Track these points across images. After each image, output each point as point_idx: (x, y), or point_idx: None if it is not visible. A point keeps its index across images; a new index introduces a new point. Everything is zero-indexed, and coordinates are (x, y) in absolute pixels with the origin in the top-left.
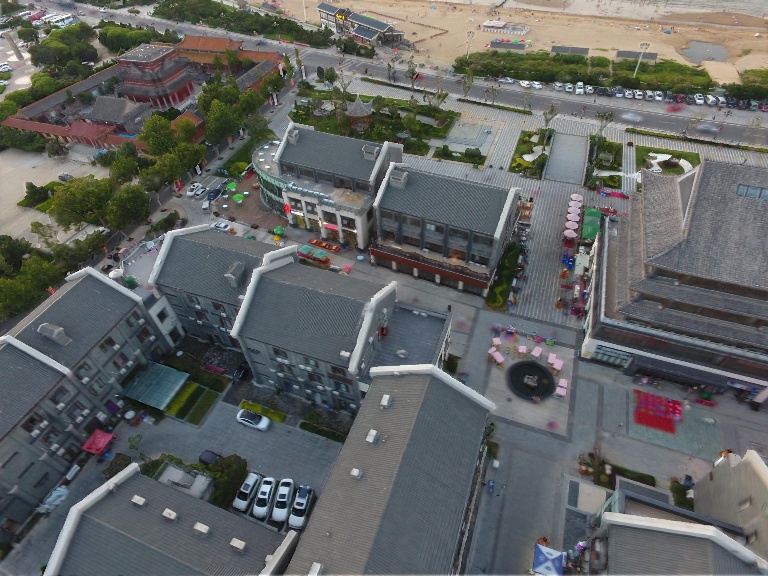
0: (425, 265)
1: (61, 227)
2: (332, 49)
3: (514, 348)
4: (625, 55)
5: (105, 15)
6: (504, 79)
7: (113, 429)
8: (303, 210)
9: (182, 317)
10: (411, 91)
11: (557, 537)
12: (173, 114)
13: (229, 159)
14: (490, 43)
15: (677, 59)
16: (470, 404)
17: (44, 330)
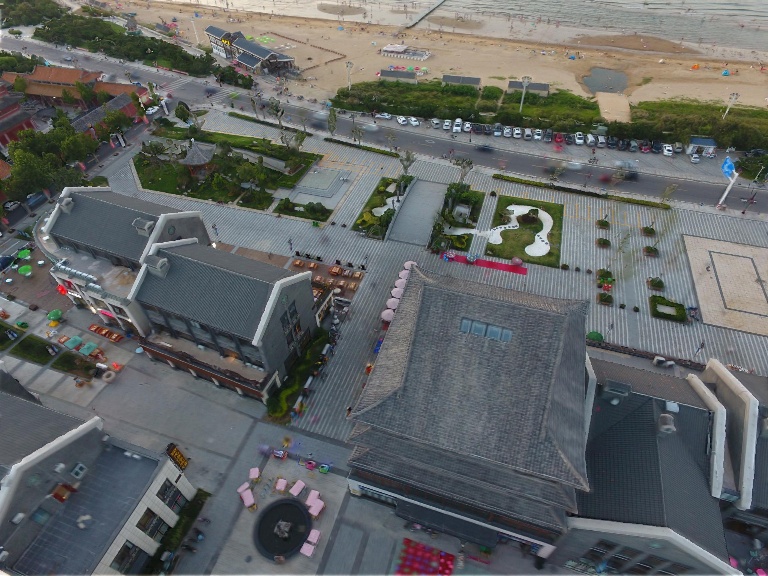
0: (195, 367)
1: None
2: (212, 78)
3: (275, 481)
4: (517, 86)
5: None
6: (381, 115)
7: None
8: (79, 292)
9: None
10: (278, 129)
11: None
12: None
13: None
14: (380, 71)
15: (573, 89)
16: None
17: None
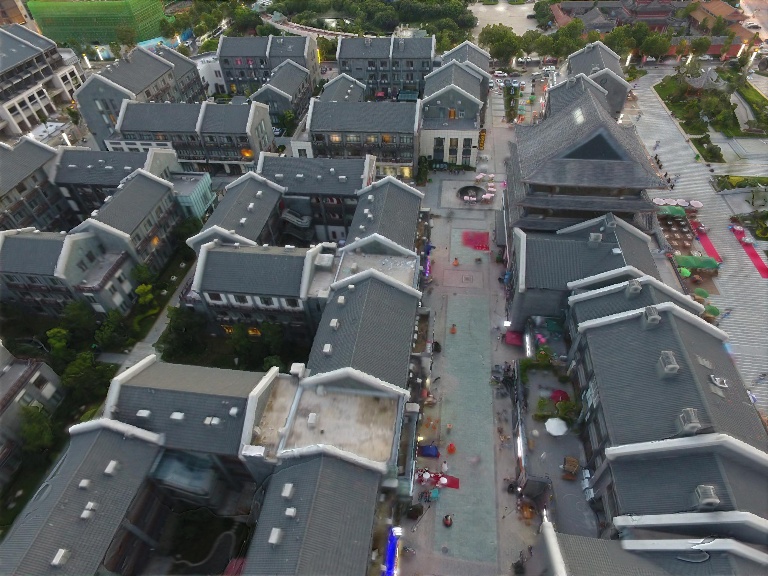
0: None
1: None
2: None
3: None
4: None
5: None
6: None
7: (388, 99)
8: None
9: None
10: None
11: None
12: None
13: None
14: None
15: None
16: (413, 123)
17: None
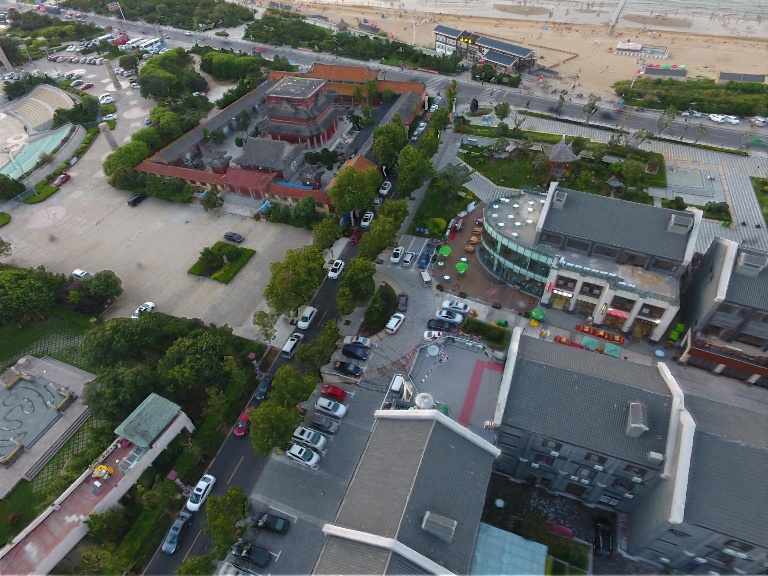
0: None
1: (277, 313)
2: (464, 76)
3: None
4: None
5: (192, 38)
6: None
7: None
8: (574, 291)
9: (502, 454)
10: (585, 127)
11: None
12: (329, 156)
13: (419, 213)
14: (644, 69)
15: None
16: None
17: (433, 526)
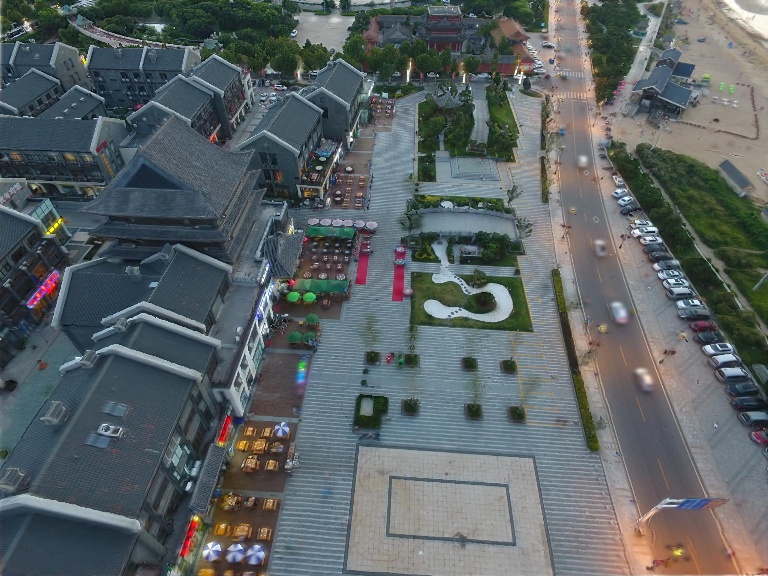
0: None
1: None
2: None
3: None
4: None
5: None
6: (616, 177)
7: None
8: None
9: None
10: (541, 132)
11: (66, 226)
12: None
13: None
14: (724, 161)
15: None
16: None
17: None
